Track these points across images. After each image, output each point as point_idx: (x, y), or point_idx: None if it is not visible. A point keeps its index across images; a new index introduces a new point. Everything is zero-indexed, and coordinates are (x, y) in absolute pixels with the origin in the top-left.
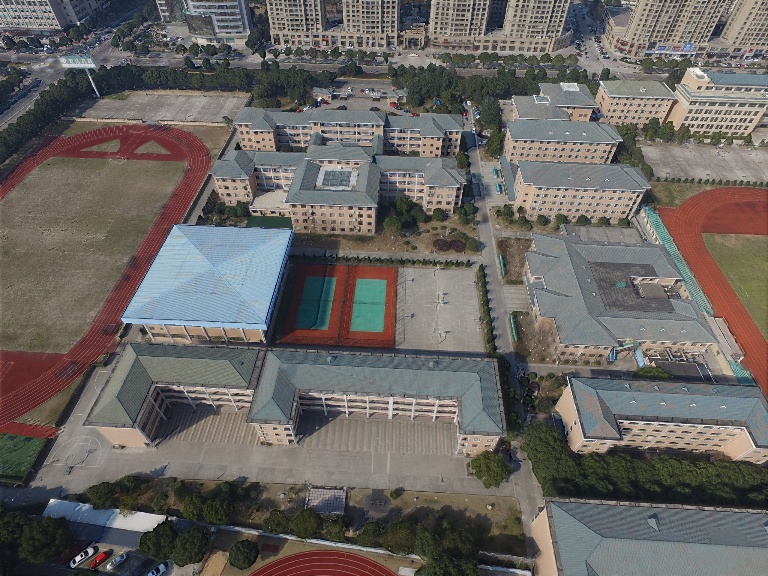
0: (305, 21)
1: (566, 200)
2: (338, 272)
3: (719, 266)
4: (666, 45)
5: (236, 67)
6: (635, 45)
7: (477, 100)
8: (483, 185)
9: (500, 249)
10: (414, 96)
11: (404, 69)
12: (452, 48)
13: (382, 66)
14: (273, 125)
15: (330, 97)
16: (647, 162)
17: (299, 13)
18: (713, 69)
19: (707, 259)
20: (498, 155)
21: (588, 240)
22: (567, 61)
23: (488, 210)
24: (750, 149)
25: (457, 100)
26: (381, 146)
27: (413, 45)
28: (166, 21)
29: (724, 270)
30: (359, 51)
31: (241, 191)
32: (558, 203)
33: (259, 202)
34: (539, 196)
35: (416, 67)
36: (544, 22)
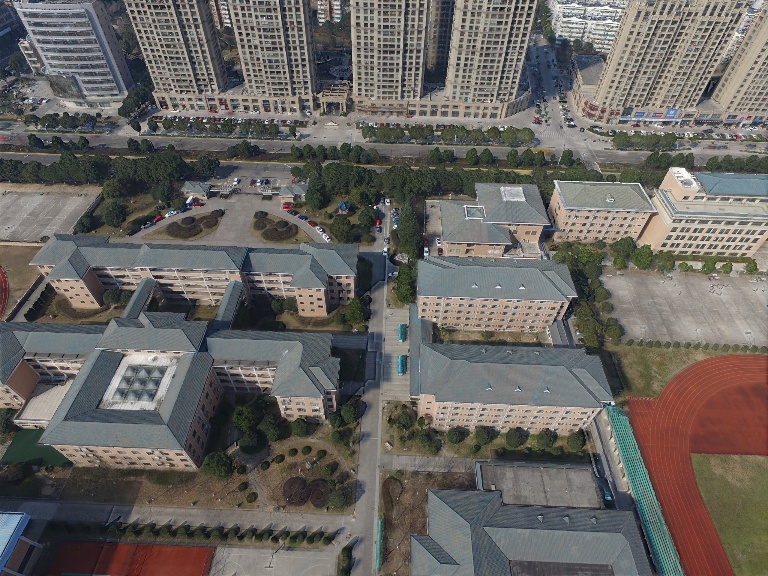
0: (195, 81)
1: (488, 412)
2: (116, 562)
3: (718, 531)
4: (645, 111)
5: (101, 144)
6: (607, 111)
7: (397, 199)
8: (381, 356)
9: (383, 500)
10: (314, 196)
11: (311, 150)
12: (381, 113)
13: (289, 141)
14: (83, 269)
15: (205, 195)
16: (615, 307)
17: (186, 72)
18: (703, 142)
19: (700, 514)
20: (409, 302)
21: (514, 502)
22: (520, 136)
23: (380, 409)
24: (755, 280)
25: (371, 200)
26: (234, 303)
27: (334, 109)
28: (38, 74)
29: (726, 541)
30: (257, 124)
31: (3, 394)
32: (476, 416)
33: (34, 408)
34: (447, 408)
35: (332, 142)
36: (493, 84)
